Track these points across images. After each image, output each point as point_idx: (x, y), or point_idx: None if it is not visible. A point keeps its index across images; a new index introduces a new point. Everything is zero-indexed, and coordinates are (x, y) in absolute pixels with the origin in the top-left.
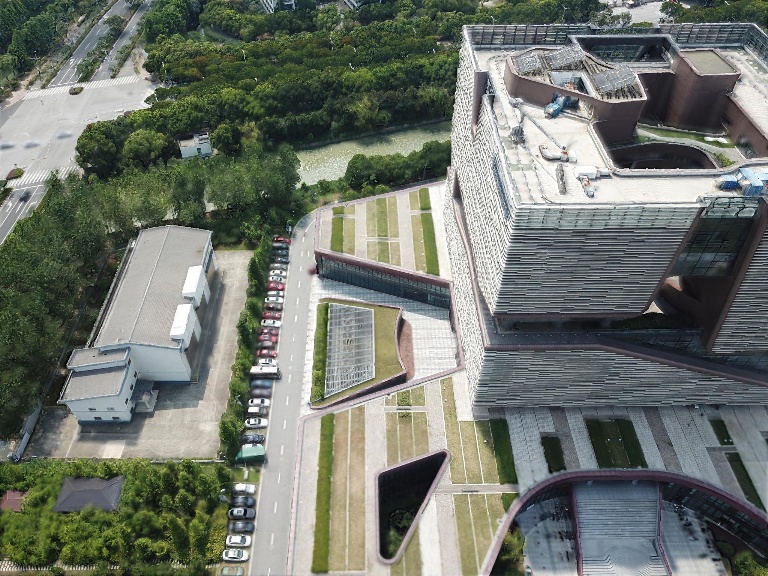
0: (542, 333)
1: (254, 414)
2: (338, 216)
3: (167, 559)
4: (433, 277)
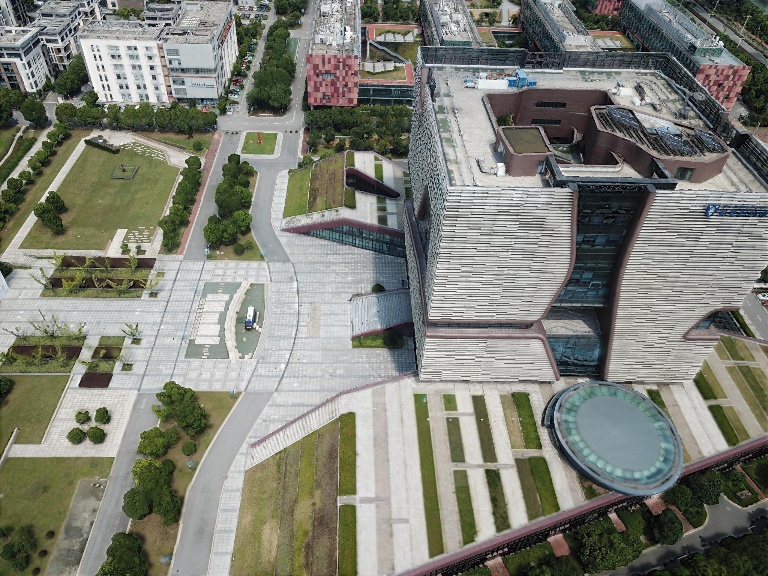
0: None
1: None
2: None
3: None
4: None
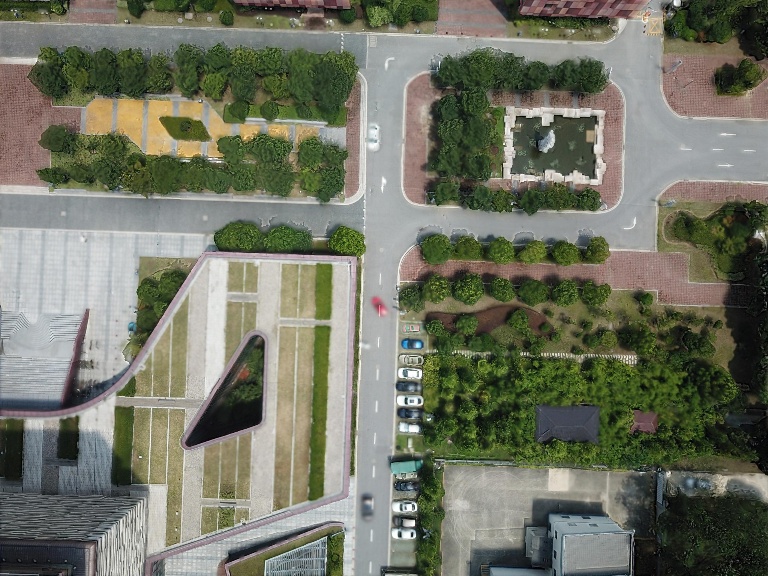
0: (14, 564)
1: (408, 518)
2: None
3: (477, 359)
4: None
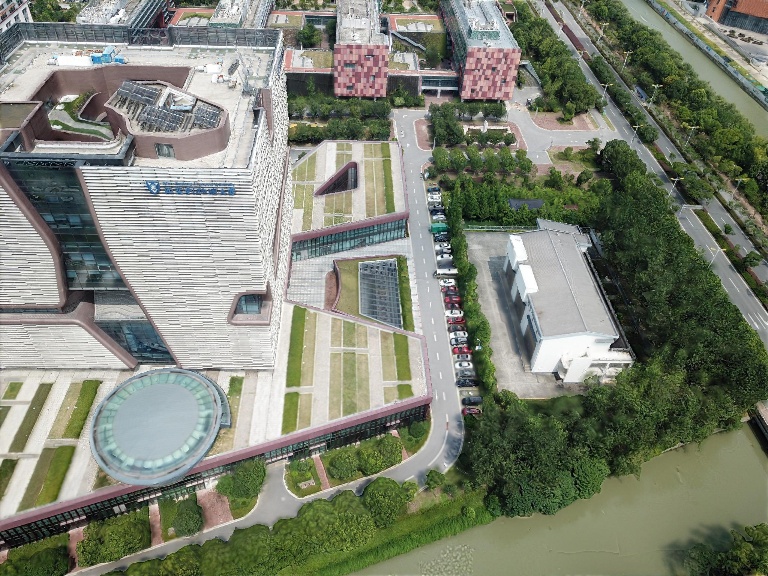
0: None
1: None
2: (404, 382)
3: None
4: (301, 304)
